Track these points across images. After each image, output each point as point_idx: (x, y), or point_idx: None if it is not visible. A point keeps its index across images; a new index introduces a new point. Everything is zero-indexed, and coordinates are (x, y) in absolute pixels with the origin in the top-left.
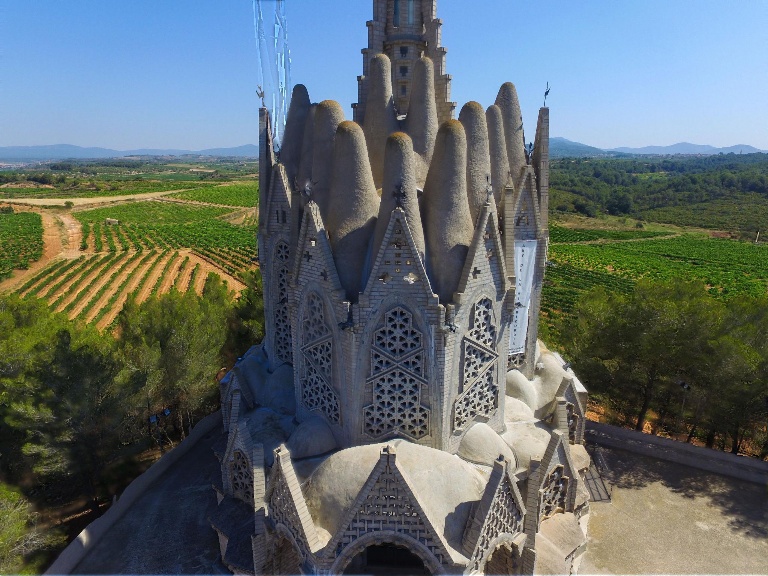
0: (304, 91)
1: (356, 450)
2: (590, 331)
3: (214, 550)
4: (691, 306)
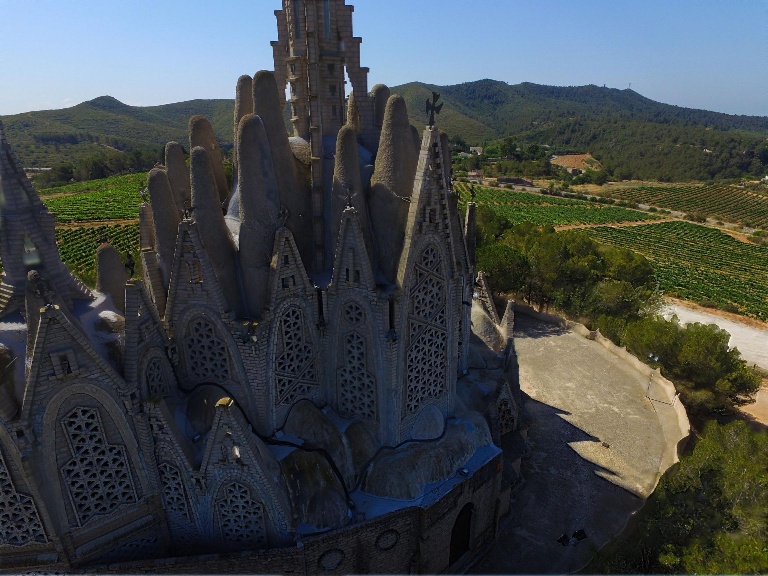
0: None
1: (473, 307)
2: None
3: (527, 469)
4: None
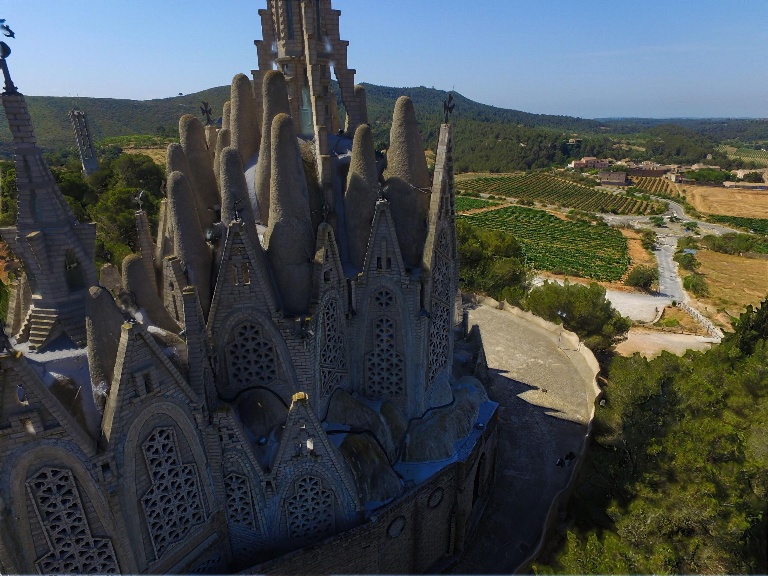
0: None
1: None
2: None
3: None
4: None
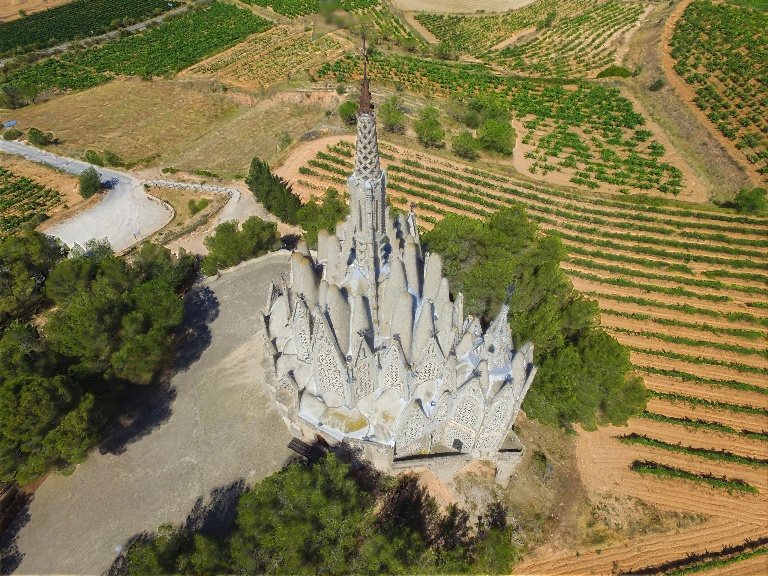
0: (397, 217)
1: None
2: None
3: None
4: (272, 477)
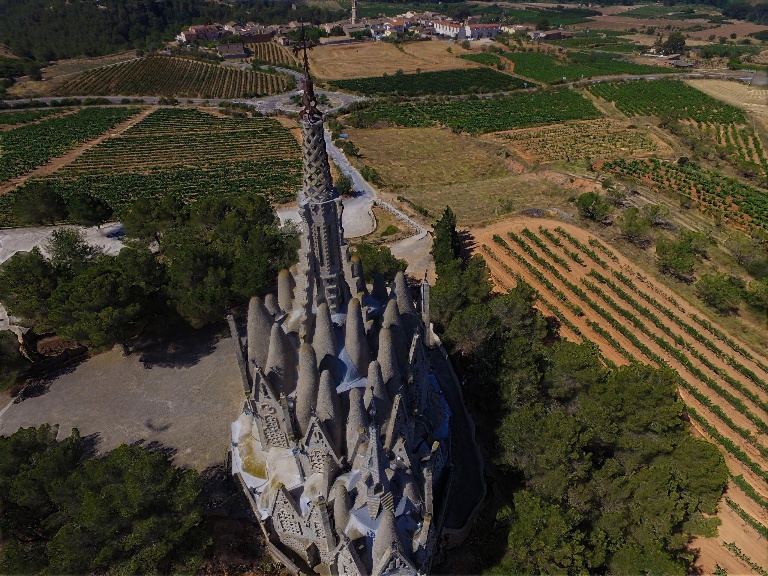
0: None
1: None
2: (200, 484)
3: None
4: None
